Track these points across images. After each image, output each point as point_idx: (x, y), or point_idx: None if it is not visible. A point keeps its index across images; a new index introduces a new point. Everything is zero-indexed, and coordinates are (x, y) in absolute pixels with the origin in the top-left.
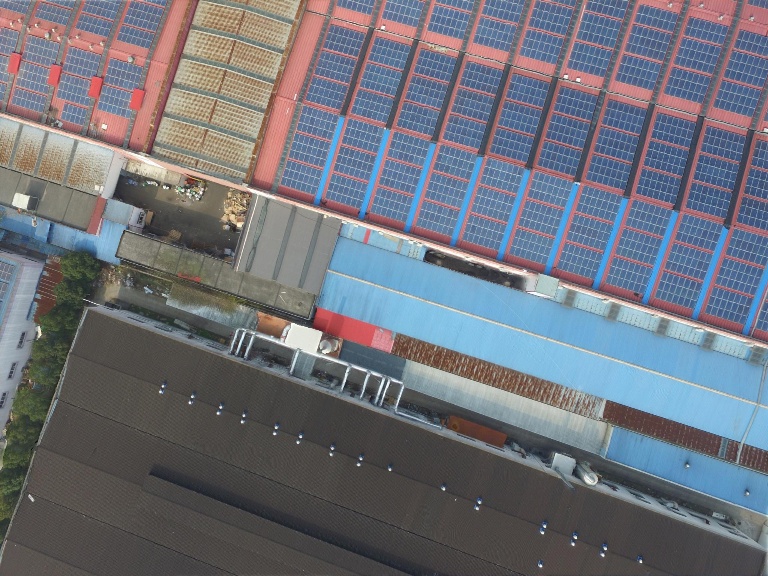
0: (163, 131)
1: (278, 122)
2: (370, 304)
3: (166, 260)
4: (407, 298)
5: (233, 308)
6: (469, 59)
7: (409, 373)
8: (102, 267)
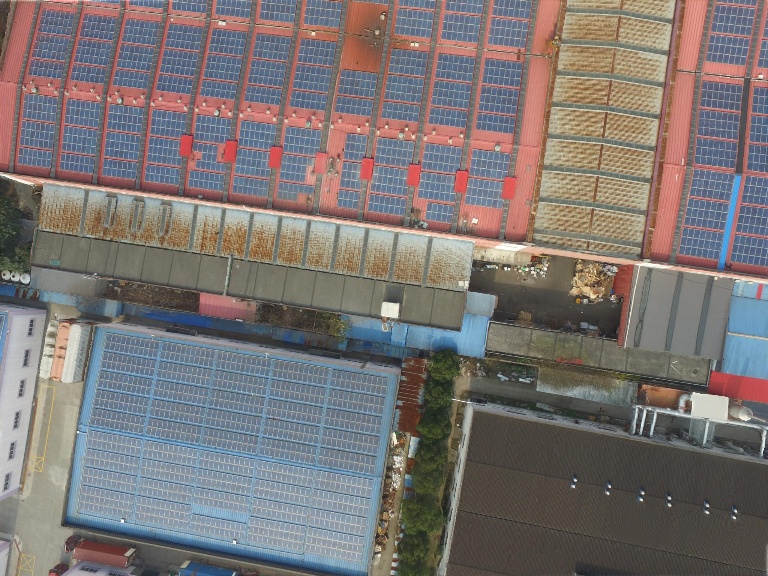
0: (541, 217)
1: (667, 190)
2: None
3: (541, 346)
4: None
5: (609, 384)
6: None
7: None
8: None
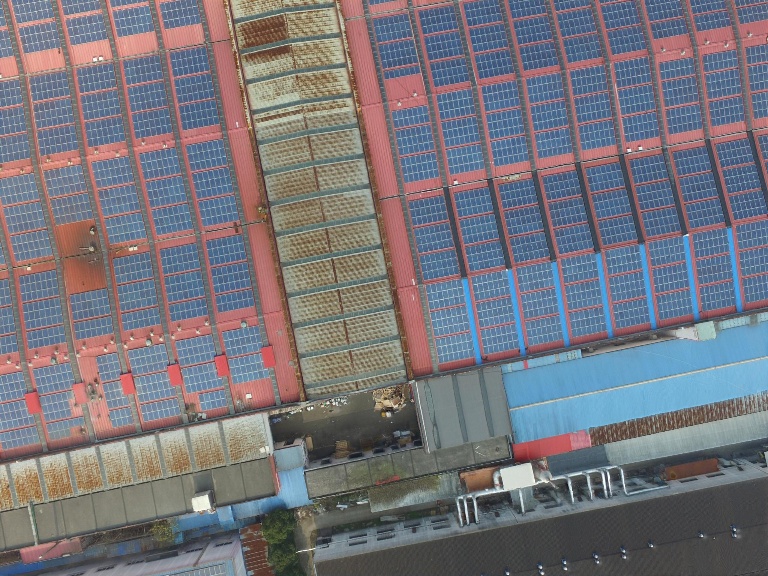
0: (307, 372)
1: (409, 311)
2: (559, 418)
3: (358, 477)
4: (588, 396)
5: (433, 482)
6: (542, 174)
7: (612, 452)
8: (293, 512)
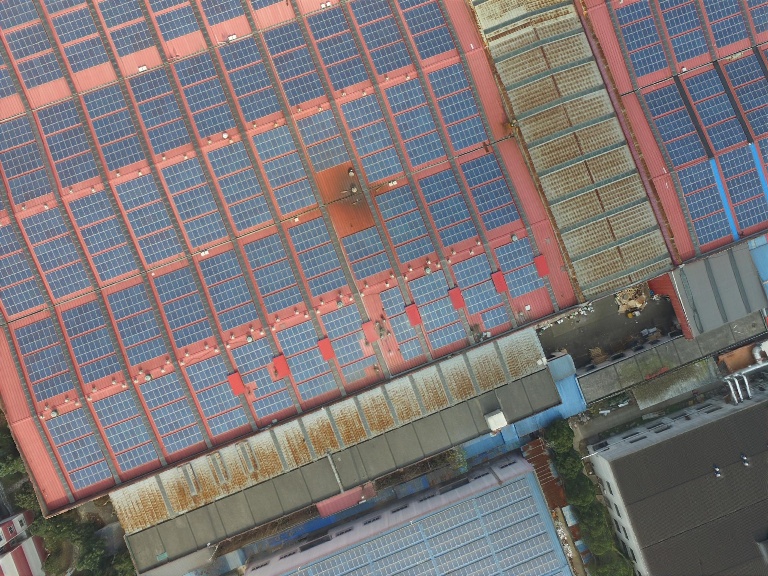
0: (579, 275)
1: (665, 199)
2: None
3: (628, 375)
4: None
5: (692, 370)
6: (762, 48)
7: None
8: None
